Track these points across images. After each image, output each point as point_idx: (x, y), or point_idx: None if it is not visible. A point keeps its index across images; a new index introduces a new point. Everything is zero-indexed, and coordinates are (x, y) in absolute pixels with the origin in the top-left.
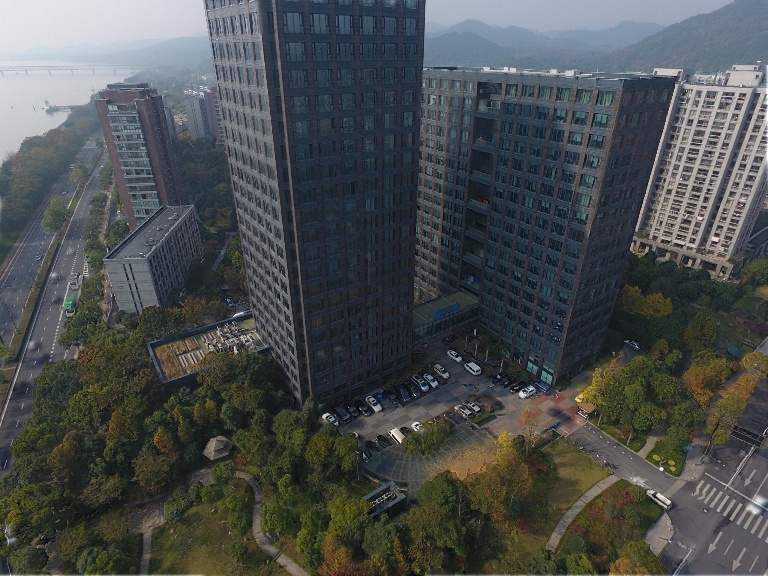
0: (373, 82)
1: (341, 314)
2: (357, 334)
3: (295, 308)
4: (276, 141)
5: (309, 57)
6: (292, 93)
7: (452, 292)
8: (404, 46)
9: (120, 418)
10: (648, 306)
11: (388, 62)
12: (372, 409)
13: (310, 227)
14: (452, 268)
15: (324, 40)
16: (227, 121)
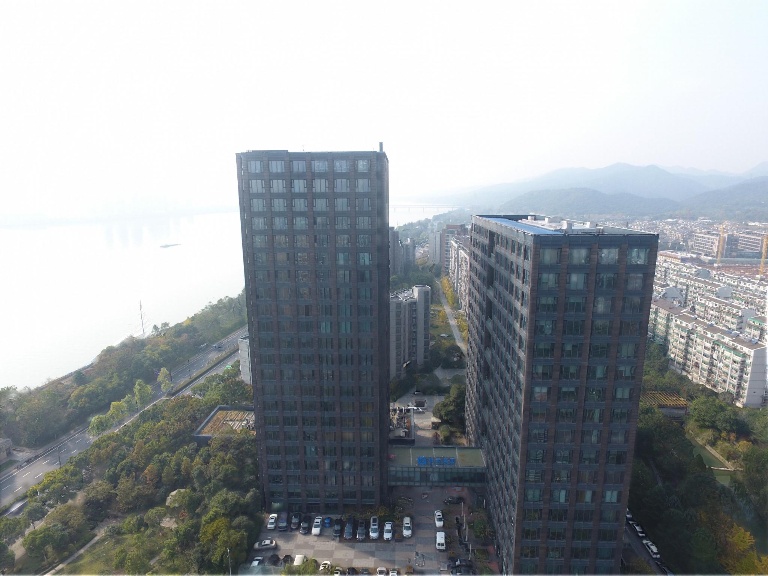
0: (326, 227)
1: (296, 421)
2: (313, 446)
3: (257, 402)
4: (246, 266)
5: (268, 208)
6: (254, 233)
7: (471, 447)
8: (357, 200)
9: (141, 446)
10: (756, 572)
11: (341, 212)
12: (311, 530)
13: (266, 335)
14: (479, 420)
15: (281, 197)
16: None
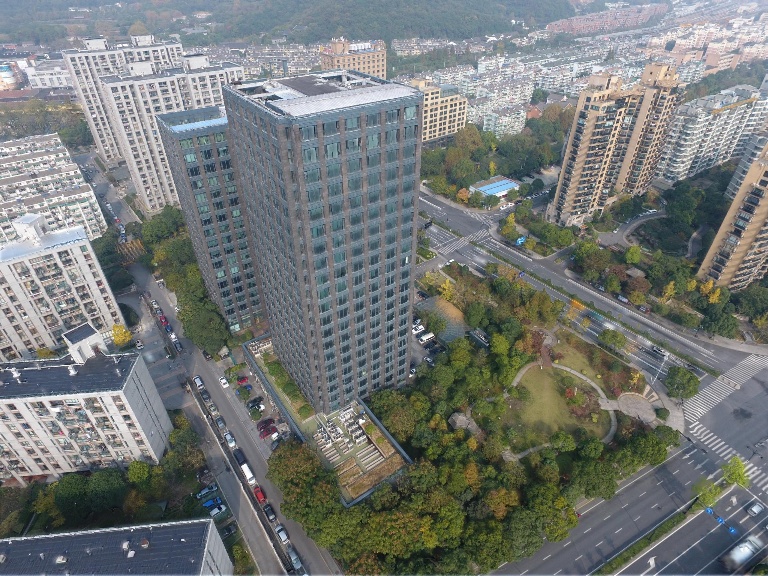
0: None
1: None
2: None
3: None
4: None
5: None
6: None
7: None
8: None
9: None
10: None
11: None
12: None
13: None
14: None
15: None
16: (321, 237)
